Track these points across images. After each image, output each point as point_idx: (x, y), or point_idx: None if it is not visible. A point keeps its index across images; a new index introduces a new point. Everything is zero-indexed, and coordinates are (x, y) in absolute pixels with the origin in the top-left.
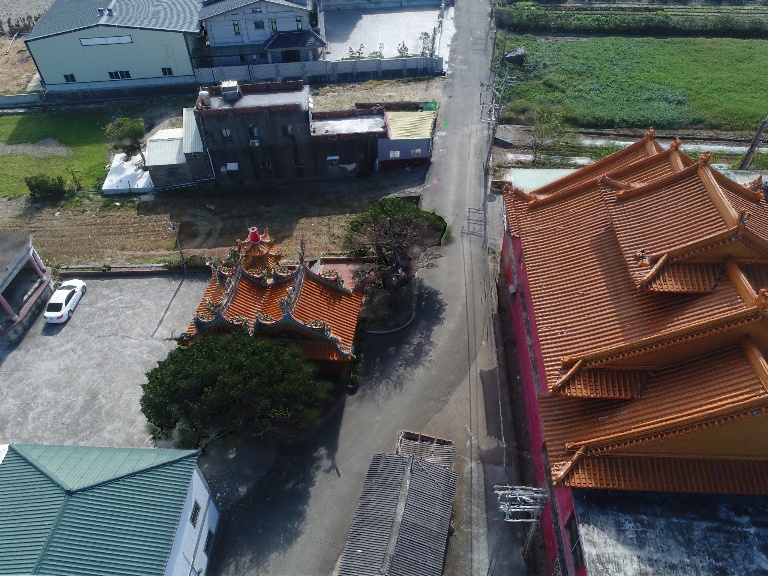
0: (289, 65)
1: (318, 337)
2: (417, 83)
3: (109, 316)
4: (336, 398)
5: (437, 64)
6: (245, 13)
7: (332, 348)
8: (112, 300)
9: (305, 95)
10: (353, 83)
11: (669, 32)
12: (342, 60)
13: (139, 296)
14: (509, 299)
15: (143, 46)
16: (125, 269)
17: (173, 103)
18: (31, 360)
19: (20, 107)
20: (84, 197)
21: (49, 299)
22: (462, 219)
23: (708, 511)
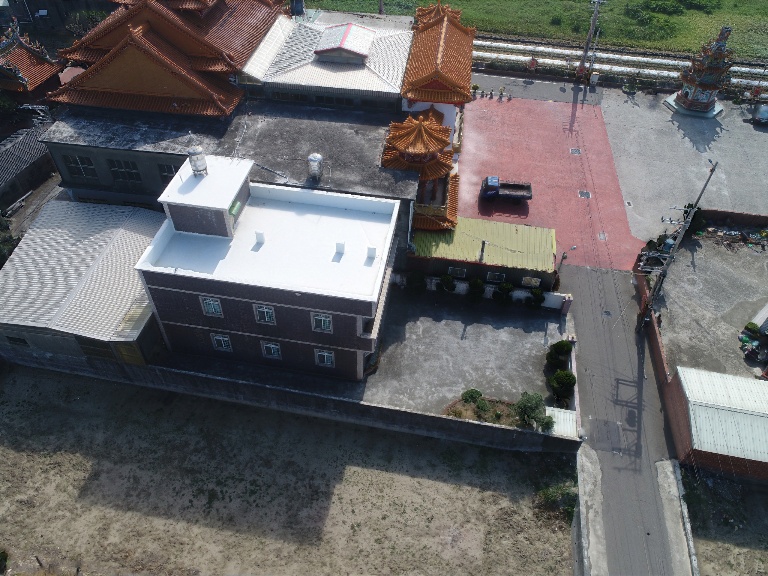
0: None
1: (12, 76)
2: None
3: None
4: (30, 124)
5: None
6: None
7: (21, 84)
8: None
9: None
10: None
11: None
12: None
13: None
14: None
15: None
16: None
17: None
18: None
19: None
20: None
21: None
22: None
23: (130, 122)
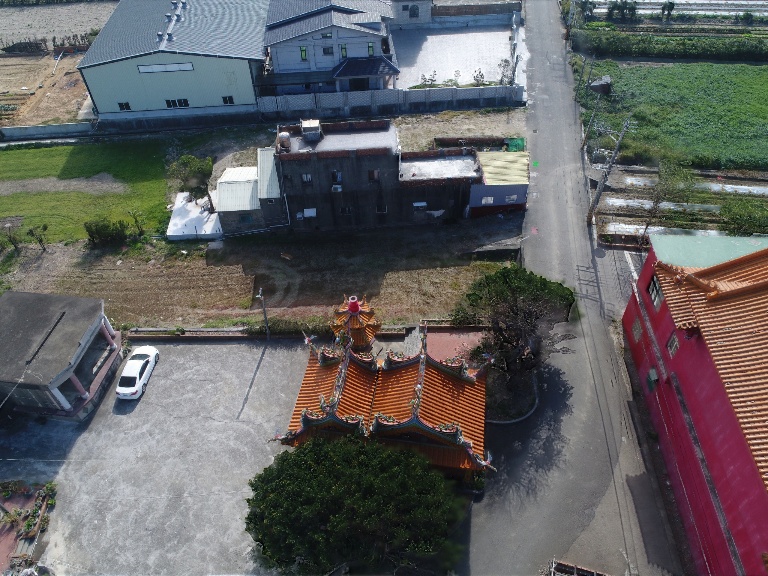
0: (358, 94)
1: (447, 441)
2: (497, 114)
3: (187, 391)
4: (460, 506)
5: (517, 93)
6: (314, 38)
7: (462, 453)
8: (189, 371)
9: (393, 136)
10: (427, 114)
11: (761, 57)
12: (415, 89)
13: (218, 367)
14: (642, 381)
15: (204, 73)
16: (201, 333)
17: (235, 135)
18: (104, 445)
19: (71, 136)
20: (147, 243)
21: (118, 368)
22: (572, 279)
23: None
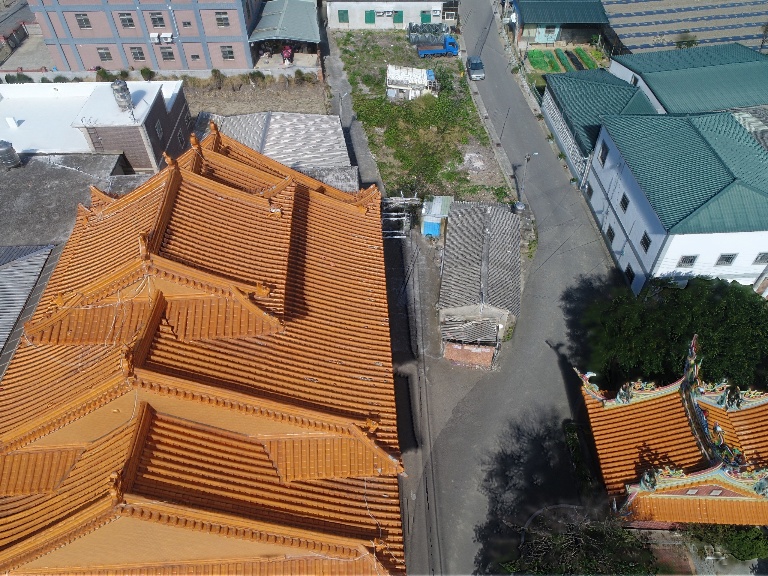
0: None
1: None
2: None
3: None
4: (583, 414)
5: None
6: None
7: None
8: None
9: None
10: None
11: None
12: None
13: None
14: None
15: None
16: None
17: None
18: None
19: None
20: None
21: None
22: None
23: None
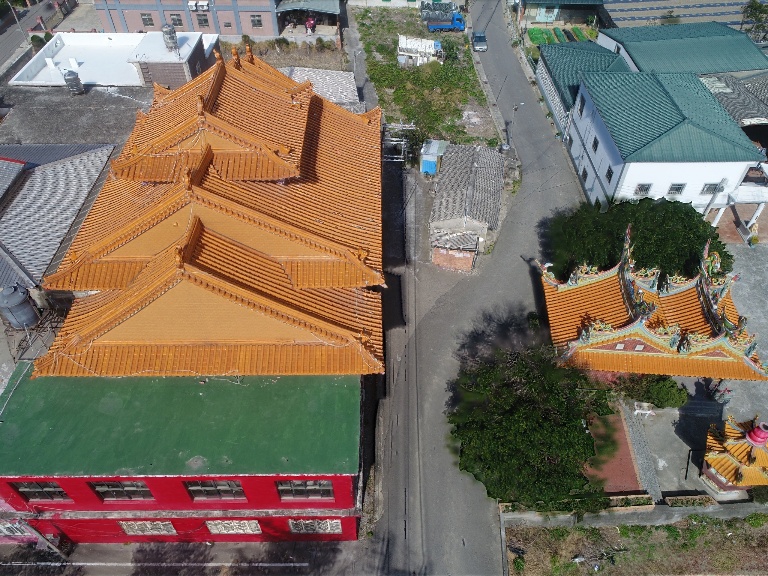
0: None
1: None
2: None
3: None
4: None
5: None
6: None
7: None
8: None
9: None
10: None
11: None
12: None
13: None
14: None
15: None
16: None
17: None
18: None
19: None
20: None
21: None
22: None
23: None
